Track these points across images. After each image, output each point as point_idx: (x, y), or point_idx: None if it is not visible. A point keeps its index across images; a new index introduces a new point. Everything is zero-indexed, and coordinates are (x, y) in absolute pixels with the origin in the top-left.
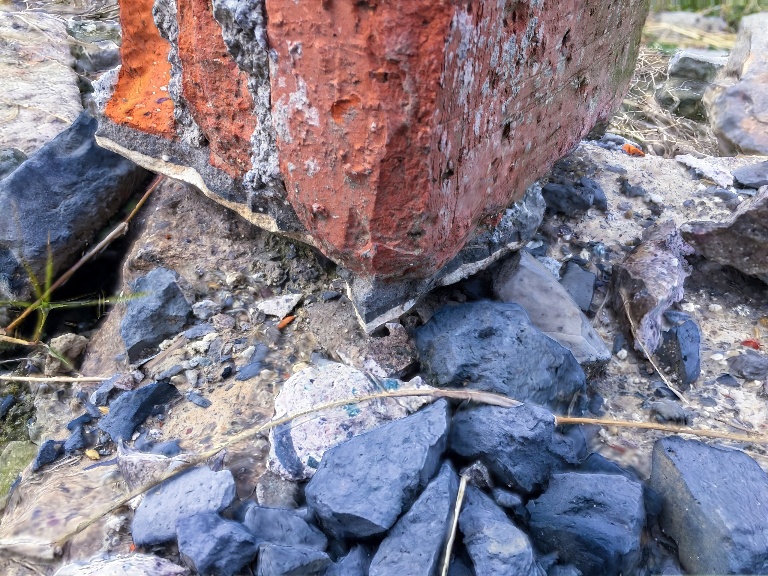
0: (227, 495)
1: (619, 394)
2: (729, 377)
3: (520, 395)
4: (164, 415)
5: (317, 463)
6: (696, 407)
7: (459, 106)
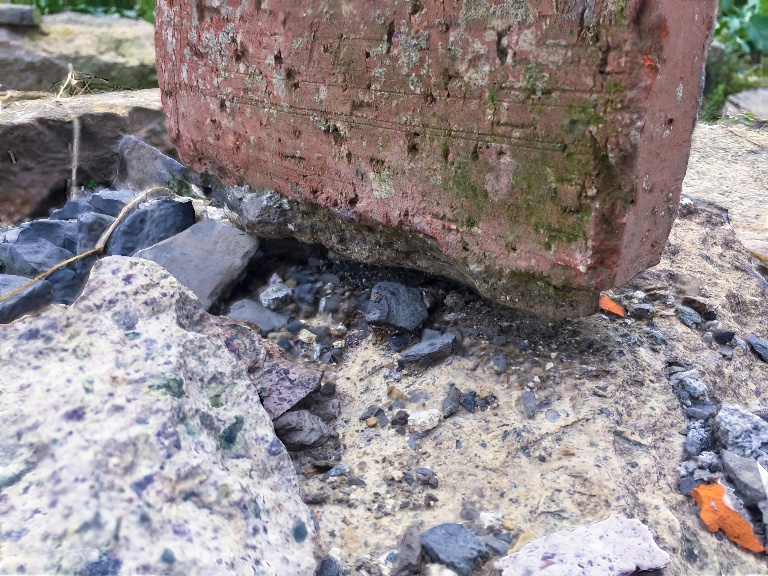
0: None
1: None
2: None
3: None
4: None
5: None
6: None
7: None
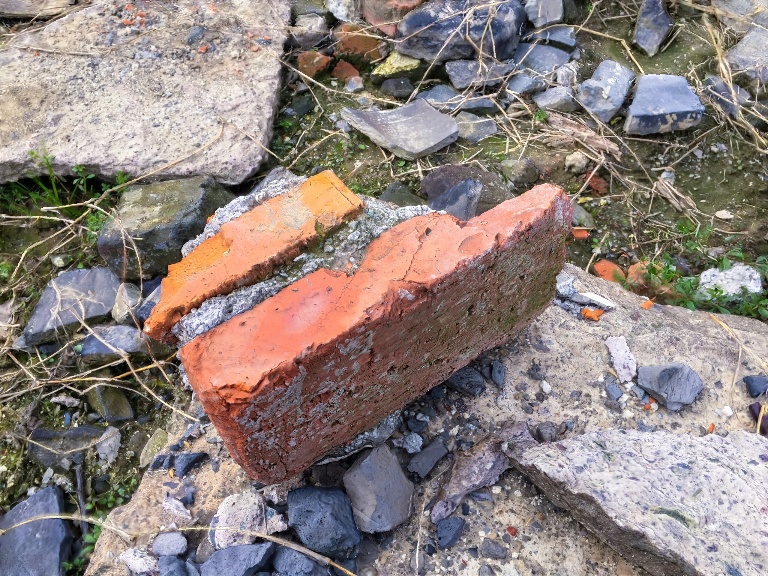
0: (183, 549)
1: (406, 539)
2: (475, 551)
3: (314, 547)
4: (199, 468)
5: (220, 547)
6: (438, 564)
7: (269, 450)
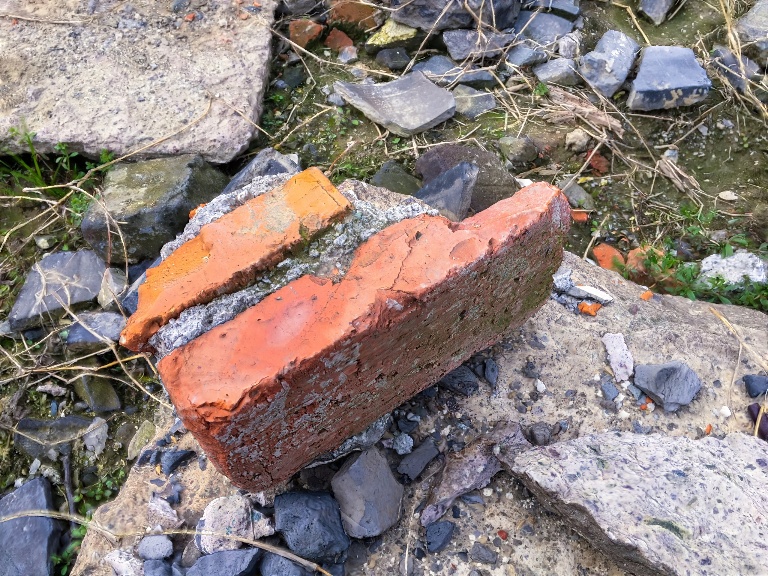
0: (168, 553)
1: (396, 542)
2: (465, 555)
3: (301, 553)
4: (186, 466)
5: (206, 551)
6: (427, 568)
7: (253, 462)
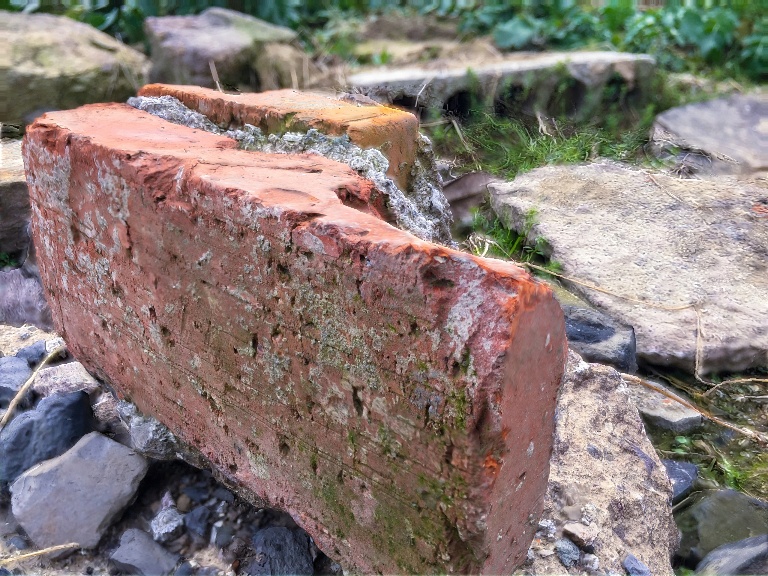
0: None
1: (19, 568)
2: None
3: (5, 432)
4: None
5: None
6: None
7: None
